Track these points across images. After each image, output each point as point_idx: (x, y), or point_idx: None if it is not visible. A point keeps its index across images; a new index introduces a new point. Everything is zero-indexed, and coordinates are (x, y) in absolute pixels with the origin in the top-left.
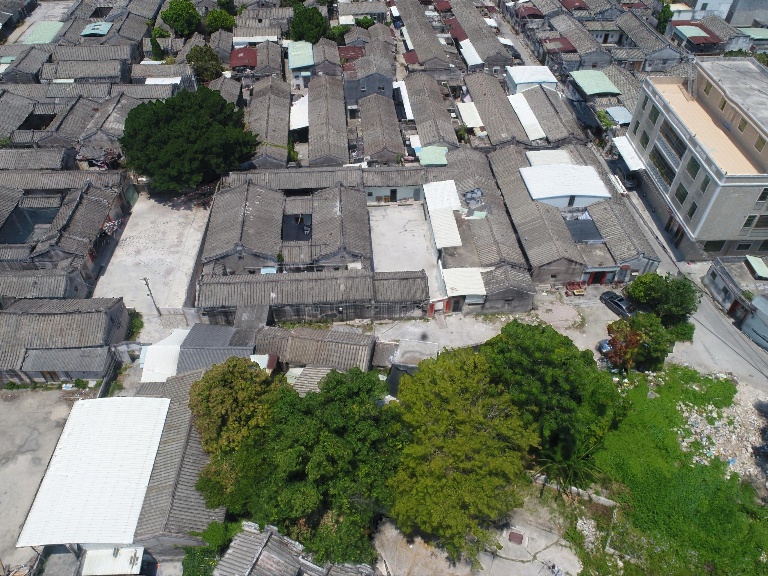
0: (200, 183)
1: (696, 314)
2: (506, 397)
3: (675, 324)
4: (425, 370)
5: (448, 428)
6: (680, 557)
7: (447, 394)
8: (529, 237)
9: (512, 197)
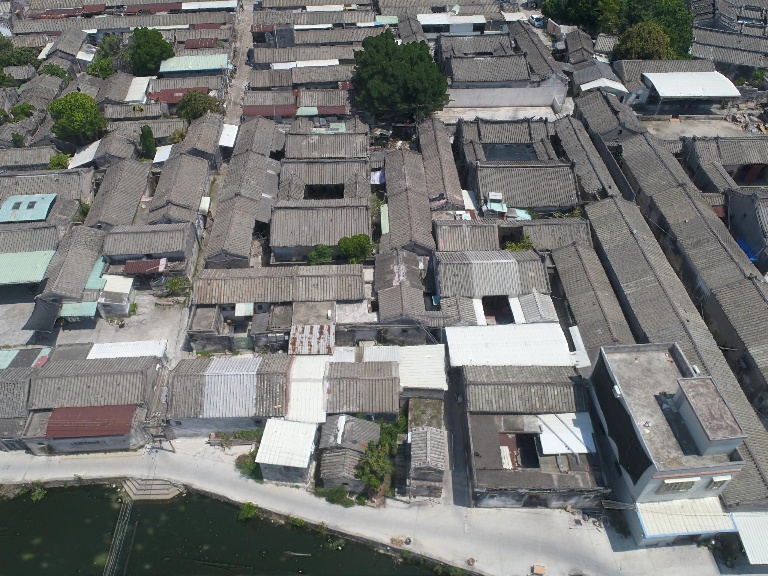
0: (404, 116)
1: None
2: None
3: None
4: None
5: None
6: None
7: None
8: (471, 1)
9: (432, 2)
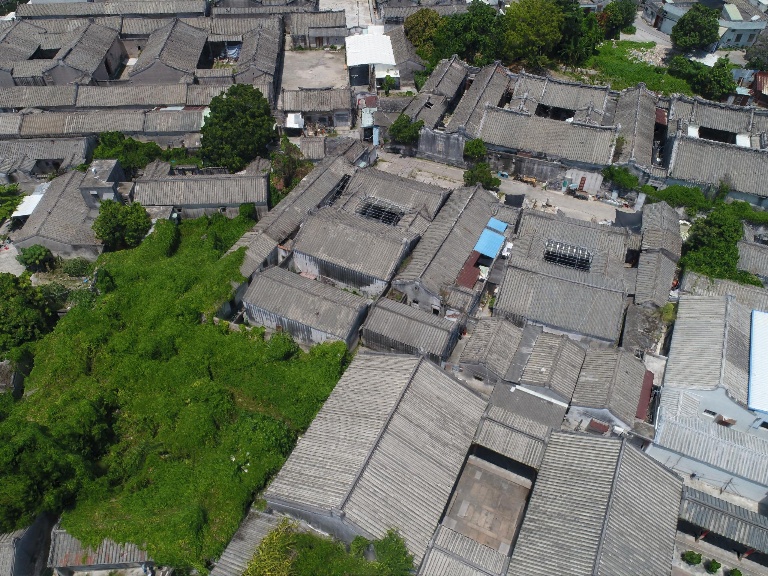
0: None
1: (637, 27)
2: (550, 3)
3: (626, 27)
4: (513, 2)
5: (527, 14)
6: (627, 82)
7: (526, 1)
8: None
9: None
